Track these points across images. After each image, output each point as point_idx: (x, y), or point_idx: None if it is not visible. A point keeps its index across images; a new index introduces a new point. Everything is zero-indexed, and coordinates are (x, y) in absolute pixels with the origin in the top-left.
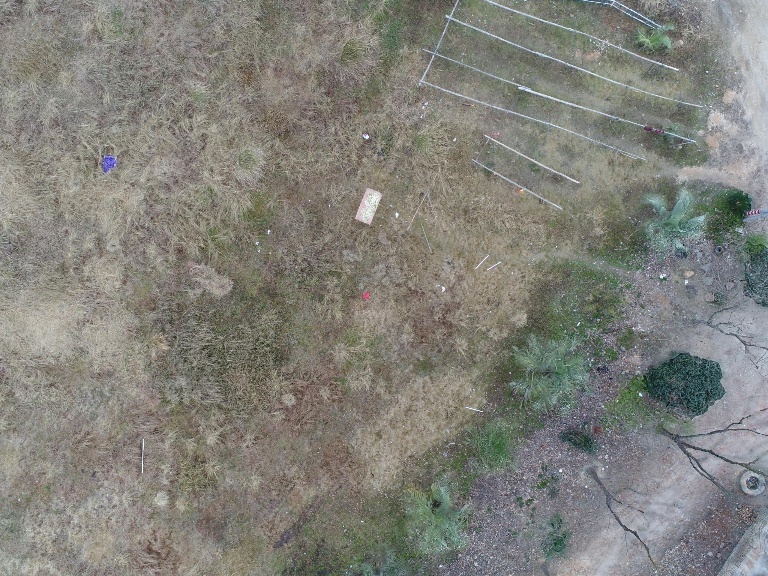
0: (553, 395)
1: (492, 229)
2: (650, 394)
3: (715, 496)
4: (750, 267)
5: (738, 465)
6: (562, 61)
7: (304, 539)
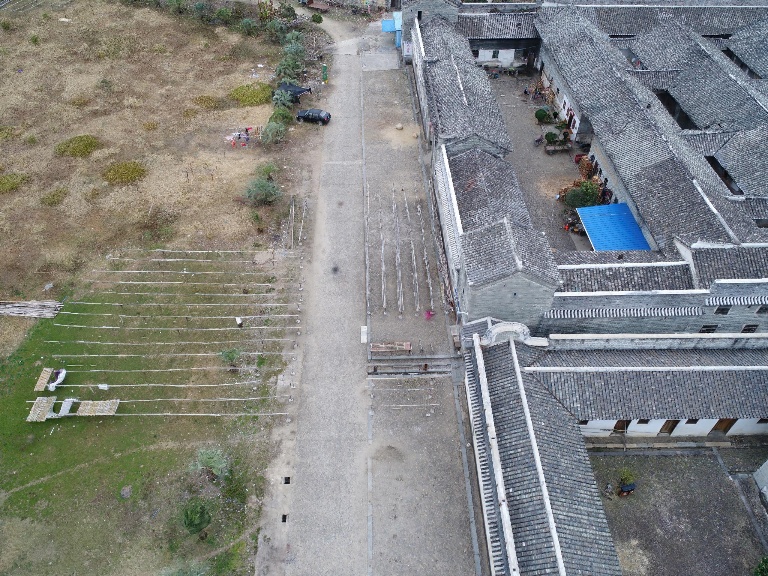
0: None
1: None
2: None
3: None
4: None
5: None
6: None
7: None
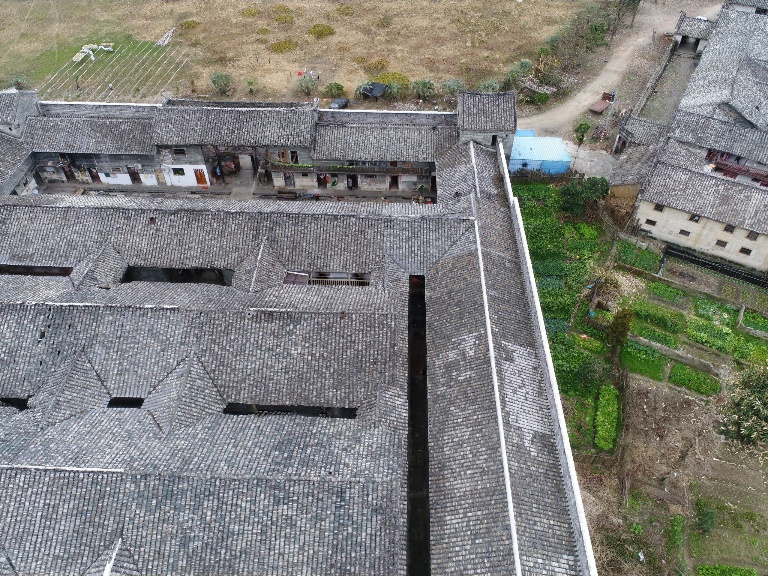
0: None
1: None
2: None
3: (658, 37)
4: None
5: None
6: None
7: None
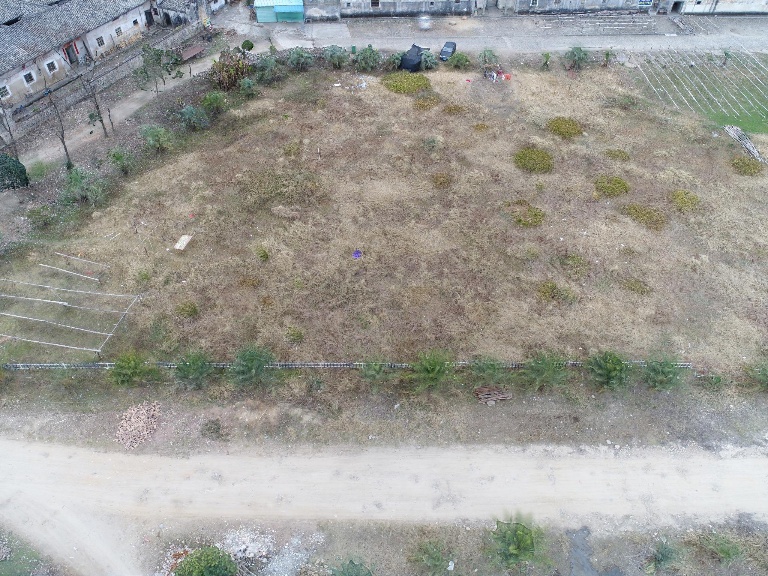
0: None
1: None
2: None
3: None
4: None
5: None
6: None
7: (232, 137)
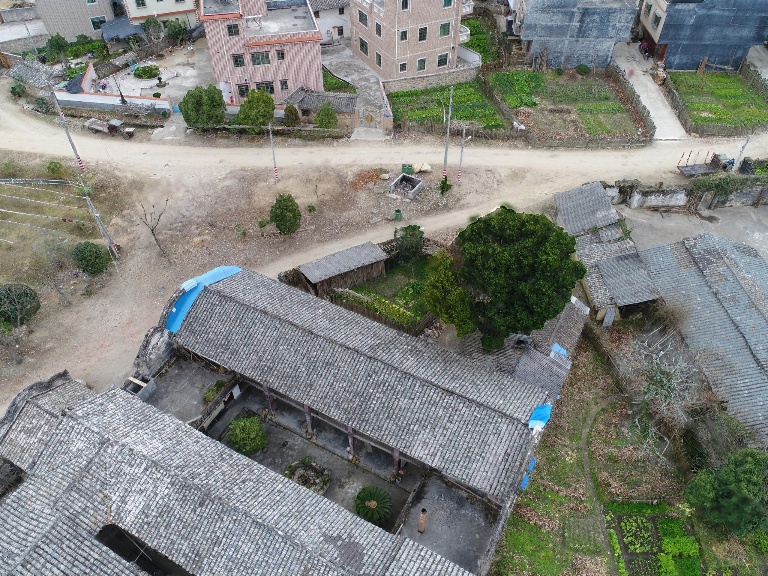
0: None
1: None
2: None
3: None
4: None
5: None
6: (26, 199)
7: None
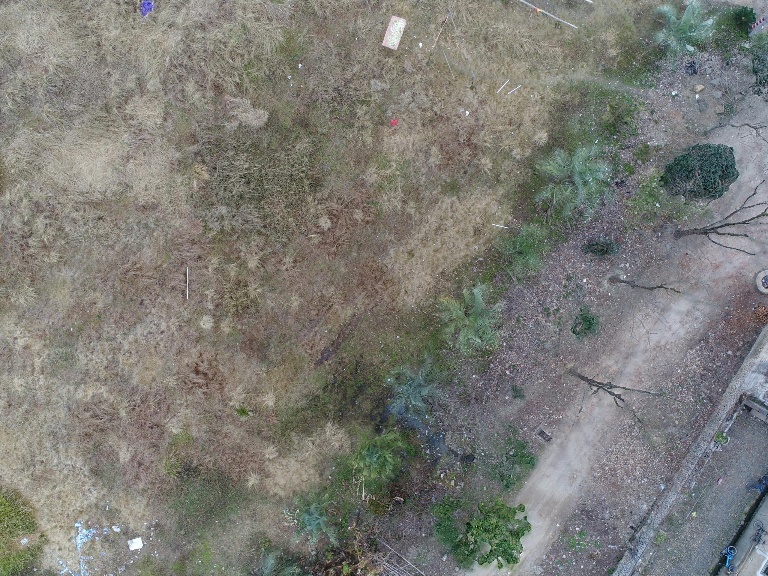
0: (575, 210)
1: (511, 55)
2: (668, 192)
3: (732, 297)
4: (758, 63)
5: (753, 267)
6: None
7: (343, 356)
